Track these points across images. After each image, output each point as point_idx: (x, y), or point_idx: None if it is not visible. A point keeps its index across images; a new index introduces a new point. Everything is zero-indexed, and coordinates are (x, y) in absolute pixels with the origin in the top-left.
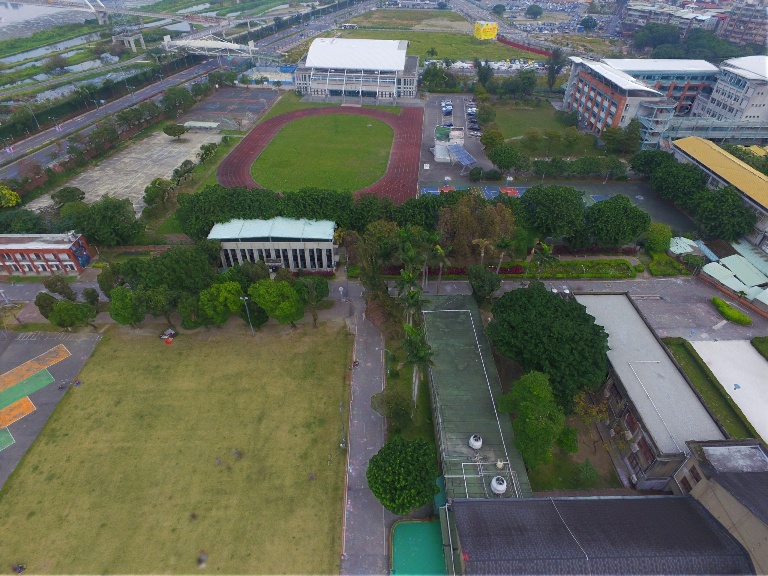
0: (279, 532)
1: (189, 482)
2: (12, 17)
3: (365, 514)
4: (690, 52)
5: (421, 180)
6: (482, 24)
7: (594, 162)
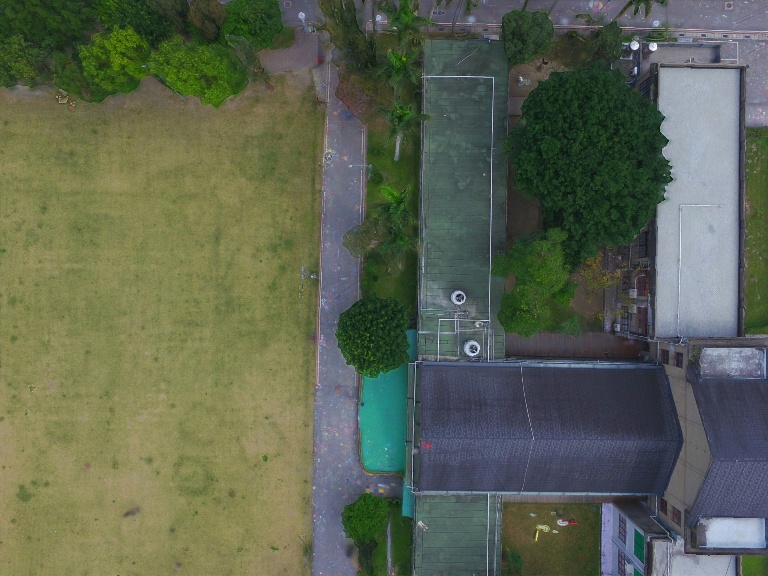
0: (256, 364)
1: (157, 312)
2: None
3: (338, 350)
4: None
5: None
6: None
7: None
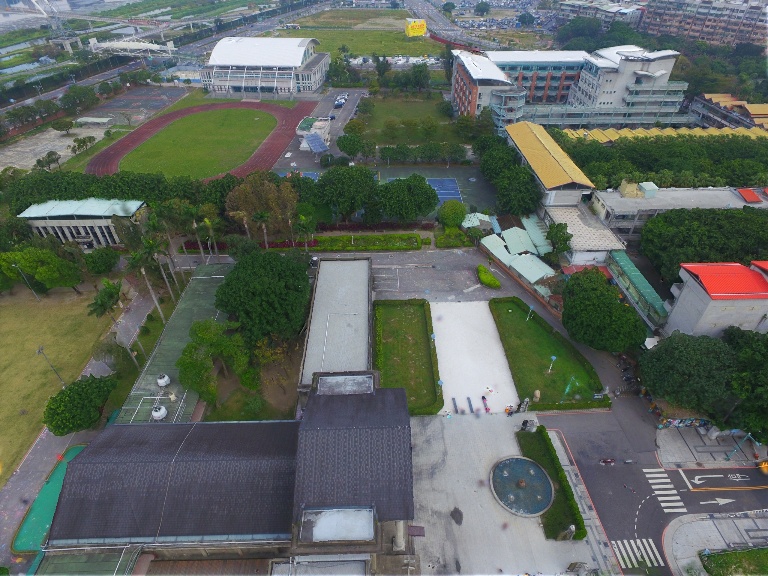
0: None
1: None
2: None
3: (54, 441)
4: (599, 44)
5: (276, 167)
6: (409, 21)
7: (434, 147)
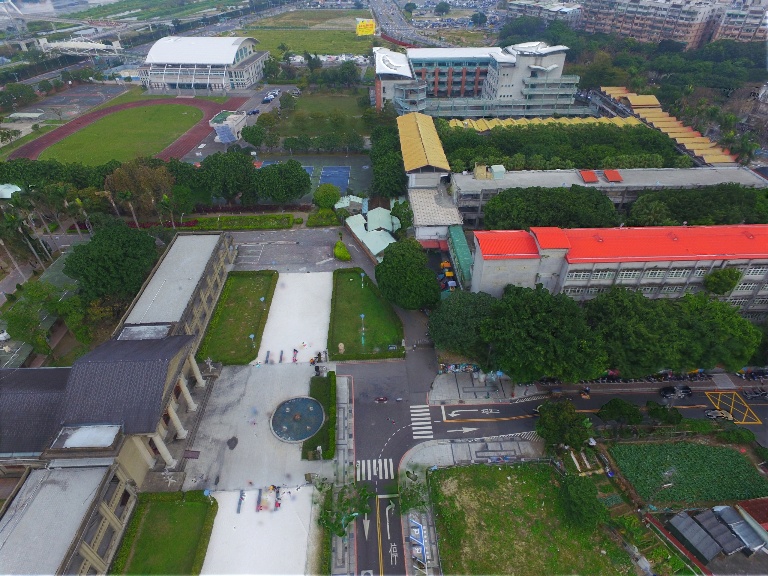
0: None
1: None
2: None
3: None
4: None
5: (186, 157)
6: (357, 21)
7: (332, 137)
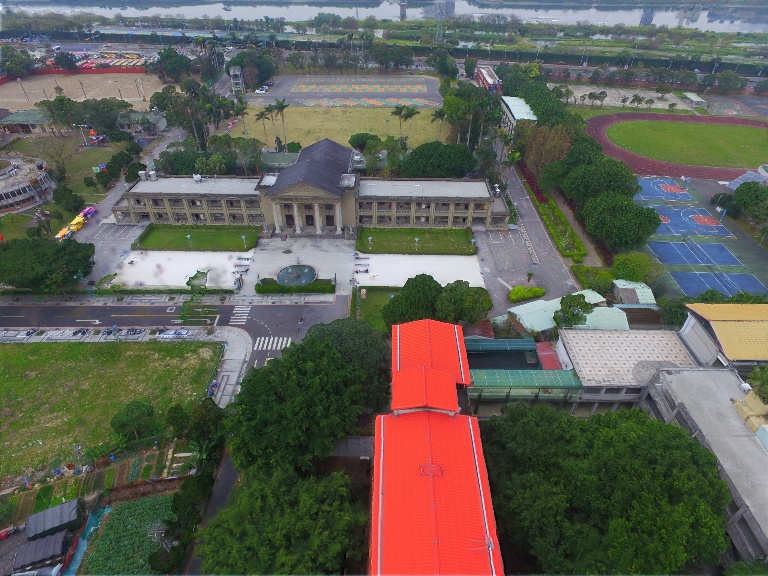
0: None
1: None
2: (741, 4)
3: (358, 152)
4: None
5: None
6: None
7: None
